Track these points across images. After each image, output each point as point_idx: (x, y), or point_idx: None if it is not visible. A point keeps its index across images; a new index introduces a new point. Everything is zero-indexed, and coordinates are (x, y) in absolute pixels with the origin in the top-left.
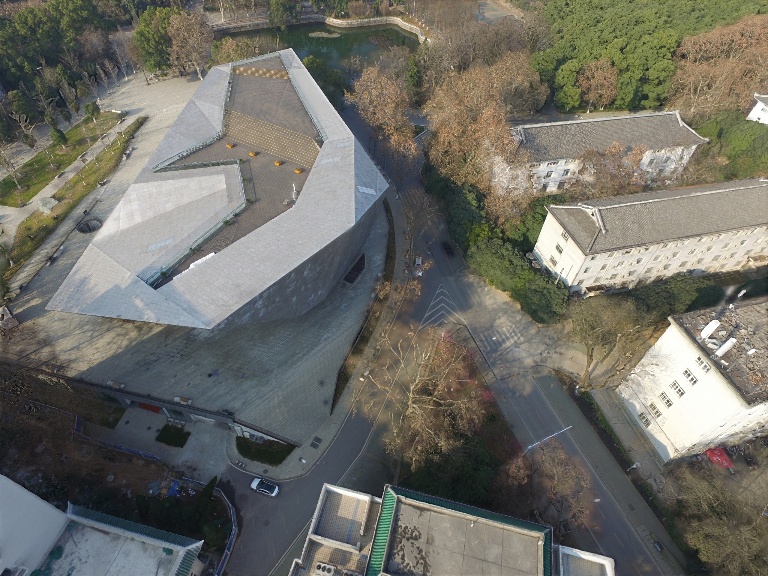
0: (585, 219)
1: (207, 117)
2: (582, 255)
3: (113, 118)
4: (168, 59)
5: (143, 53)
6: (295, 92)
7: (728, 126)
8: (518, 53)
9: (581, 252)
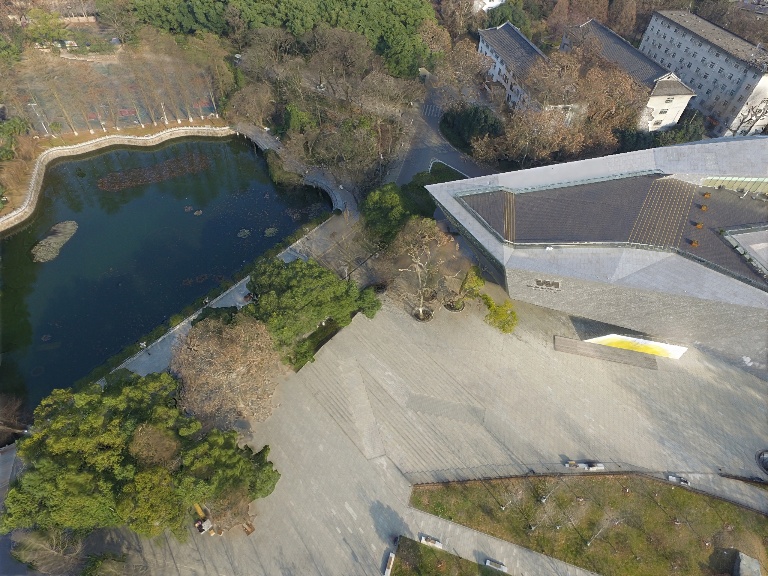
0: (668, 83)
1: (647, 266)
2: (689, 98)
3: (418, 567)
4: (236, 447)
5: (247, 486)
6: (551, 190)
7: (490, 19)
8: (463, 41)
9: (694, 95)
